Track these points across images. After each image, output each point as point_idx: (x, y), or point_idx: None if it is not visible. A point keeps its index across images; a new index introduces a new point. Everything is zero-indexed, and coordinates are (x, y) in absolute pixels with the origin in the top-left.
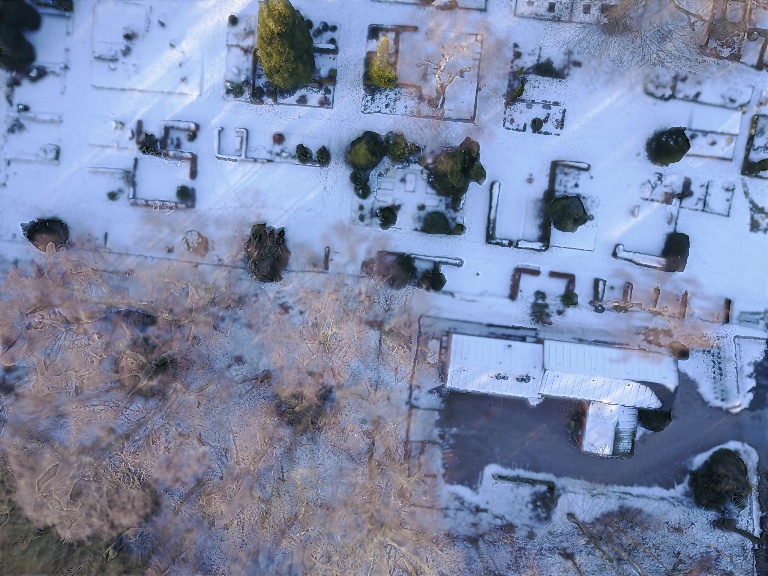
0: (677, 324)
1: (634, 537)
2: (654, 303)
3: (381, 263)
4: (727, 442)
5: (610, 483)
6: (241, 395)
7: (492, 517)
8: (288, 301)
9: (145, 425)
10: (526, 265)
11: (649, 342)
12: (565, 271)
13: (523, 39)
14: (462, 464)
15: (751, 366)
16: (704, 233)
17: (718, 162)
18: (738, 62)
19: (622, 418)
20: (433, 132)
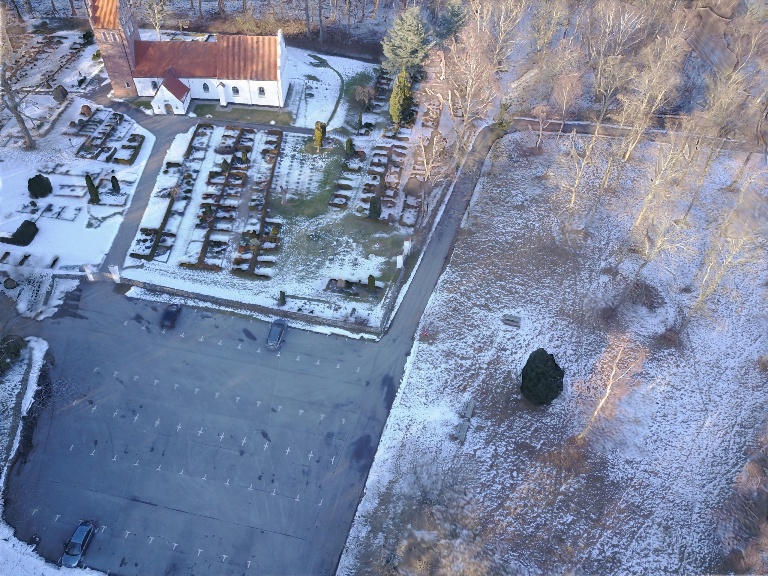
0: (13, 268)
1: None
2: None
3: None
4: (26, 337)
5: None
6: None
7: None
8: None
9: None
10: None
11: None
12: None
13: None
14: None
15: (63, 293)
16: (54, 228)
17: (75, 199)
18: (96, 160)
19: None
20: None
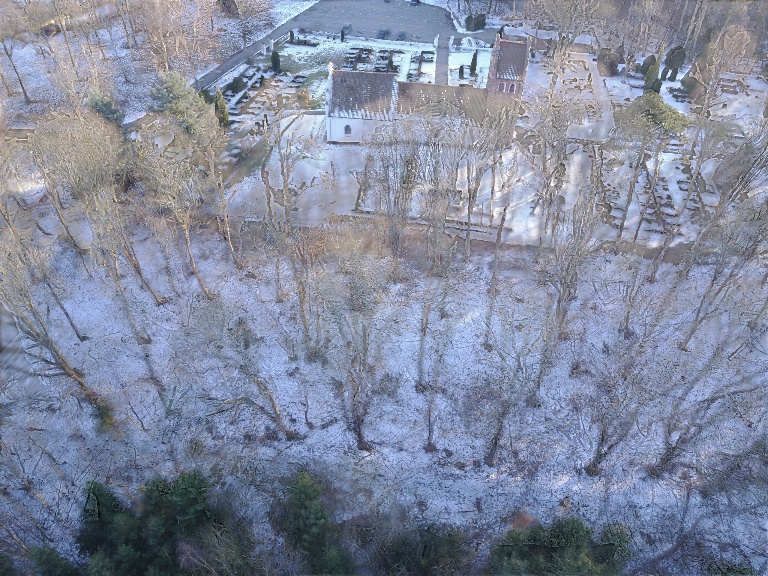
0: None
1: None
2: None
3: None
4: None
5: None
6: (670, 27)
7: None
8: None
9: (704, 3)
10: None
11: None
12: None
13: None
14: None
15: None
16: None
17: None
18: None
19: None
20: None
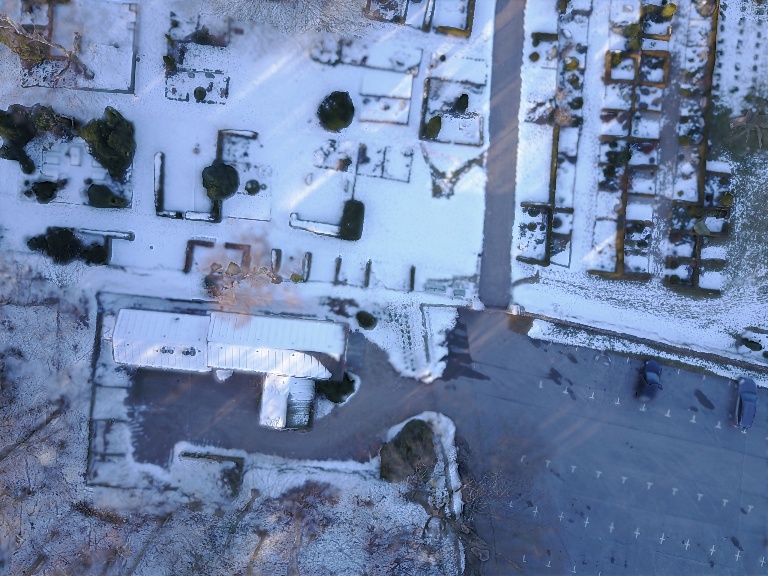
0: (360, 293)
1: (325, 512)
2: (335, 272)
3: None
4: (421, 413)
5: (304, 458)
6: None
7: (180, 495)
8: None
9: None
10: (202, 237)
11: (336, 313)
12: (242, 242)
13: (180, 7)
14: (152, 442)
15: (442, 334)
16: (385, 200)
17: (395, 127)
18: (404, 24)
19: (295, 390)
20: (94, 104)
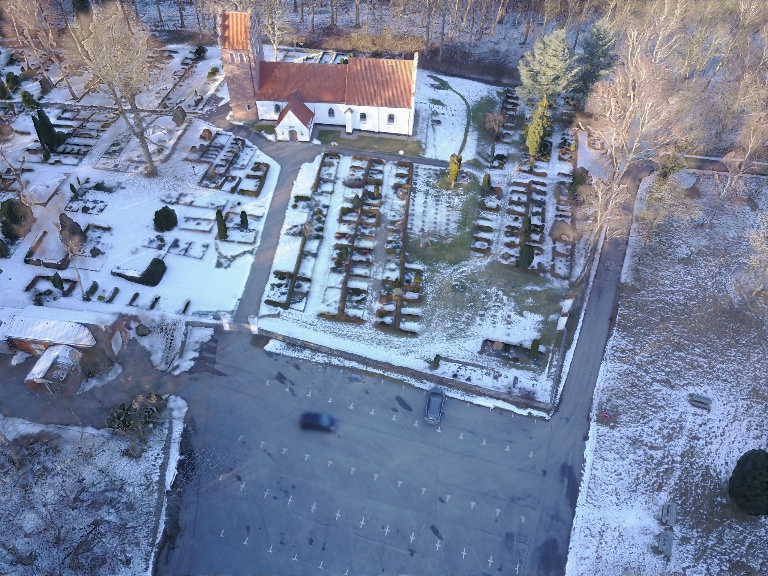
0: (144, 312)
1: (45, 461)
2: None
3: None
4: (163, 395)
5: None
6: None
7: None
8: None
9: None
10: None
11: None
12: None
13: (94, 177)
14: None
15: (198, 344)
16: (182, 267)
17: (201, 234)
18: (220, 190)
19: (64, 354)
20: None
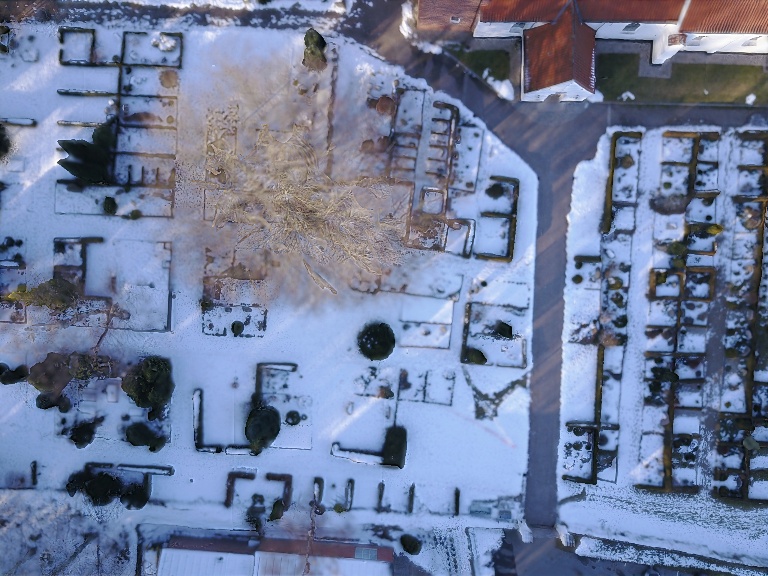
0: (404, 519)
1: None
2: (378, 499)
3: (89, 476)
4: None
5: None
6: None
7: None
8: (2, 515)
9: None
10: (242, 468)
11: (380, 536)
12: (283, 472)
13: (215, 243)
14: None
15: (488, 555)
16: (427, 423)
17: (436, 351)
18: (443, 252)
19: None
20: (130, 342)
